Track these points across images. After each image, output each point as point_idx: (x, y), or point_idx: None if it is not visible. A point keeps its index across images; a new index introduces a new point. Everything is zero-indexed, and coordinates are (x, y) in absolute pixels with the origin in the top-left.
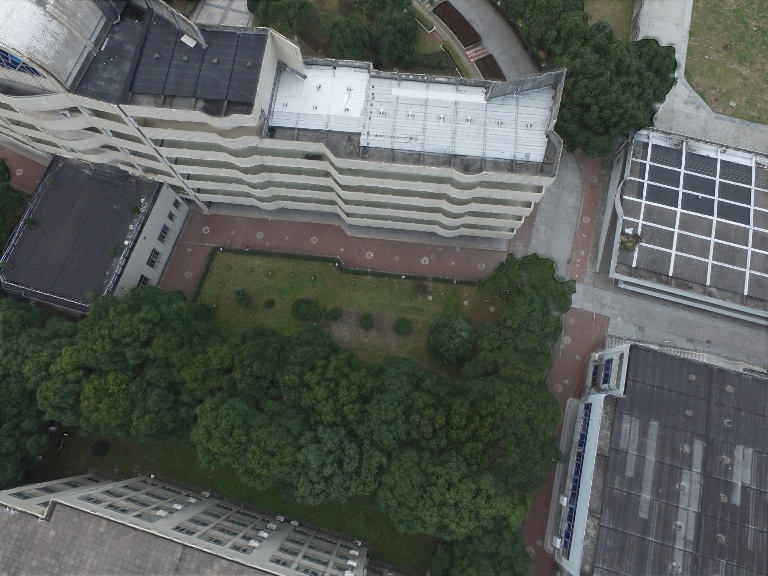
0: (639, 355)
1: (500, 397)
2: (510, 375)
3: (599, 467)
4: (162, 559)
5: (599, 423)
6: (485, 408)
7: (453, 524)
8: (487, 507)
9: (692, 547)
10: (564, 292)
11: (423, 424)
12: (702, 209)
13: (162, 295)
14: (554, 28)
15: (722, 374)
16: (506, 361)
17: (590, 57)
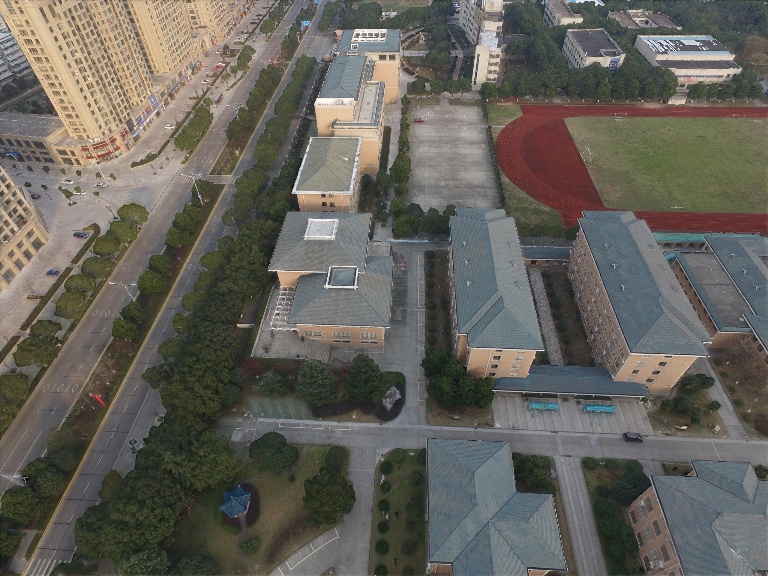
0: None
1: (512, 4)
2: None
3: None
4: (556, 9)
5: (508, 2)
6: (514, 4)
7: None
8: None
9: None
10: None
11: (521, 5)
12: None
13: (519, 24)
14: (434, 8)
15: None
16: (505, 6)
17: (444, 1)
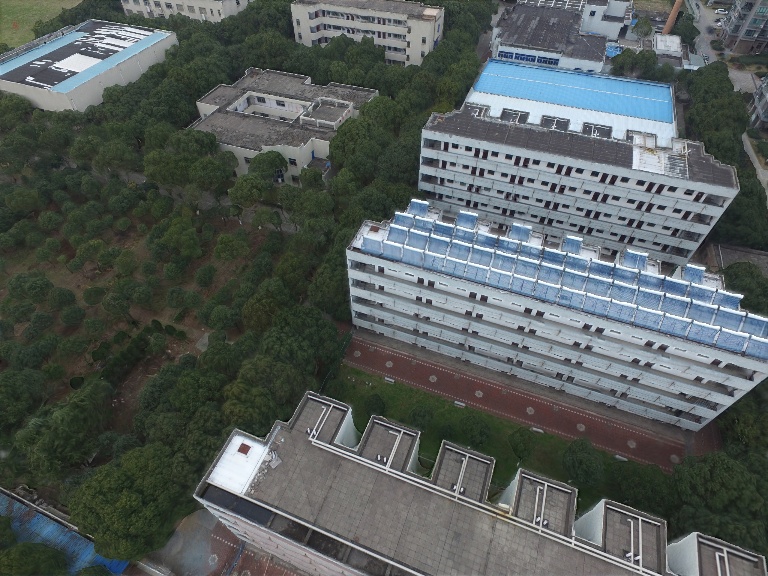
0: (519, 6)
1: None
2: (473, 0)
3: (504, 21)
4: None
5: None
6: None
7: (452, 8)
8: (463, 5)
9: (534, 28)
10: (495, 4)
11: None
12: (549, 0)
13: None
14: None
15: (548, 9)
16: None
17: None
